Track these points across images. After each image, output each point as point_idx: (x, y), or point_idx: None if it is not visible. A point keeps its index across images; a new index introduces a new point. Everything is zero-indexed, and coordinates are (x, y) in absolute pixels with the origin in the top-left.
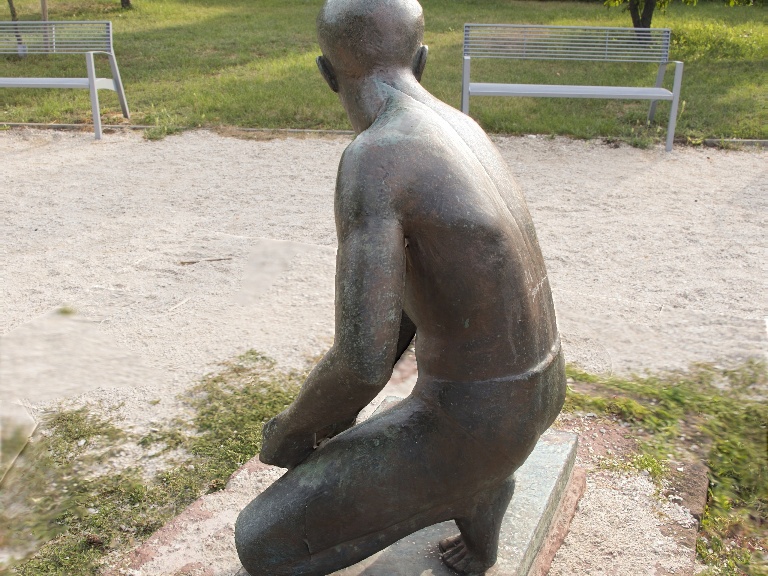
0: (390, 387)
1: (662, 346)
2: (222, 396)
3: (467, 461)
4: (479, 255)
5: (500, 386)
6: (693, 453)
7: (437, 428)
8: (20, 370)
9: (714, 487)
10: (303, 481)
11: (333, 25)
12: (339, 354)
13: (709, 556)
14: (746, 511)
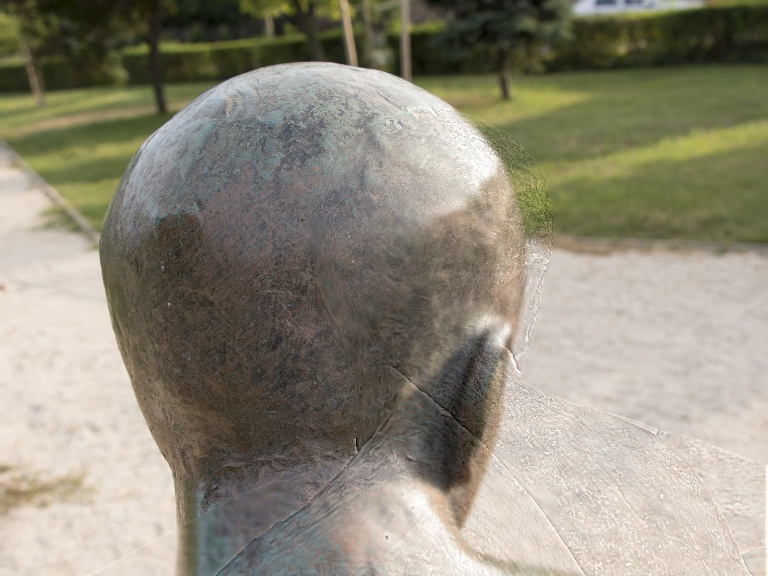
0: None
1: None
2: None
3: None
4: None
5: None
6: None
7: None
8: (195, 573)
9: None
10: None
11: (308, 220)
12: None
13: None
14: None
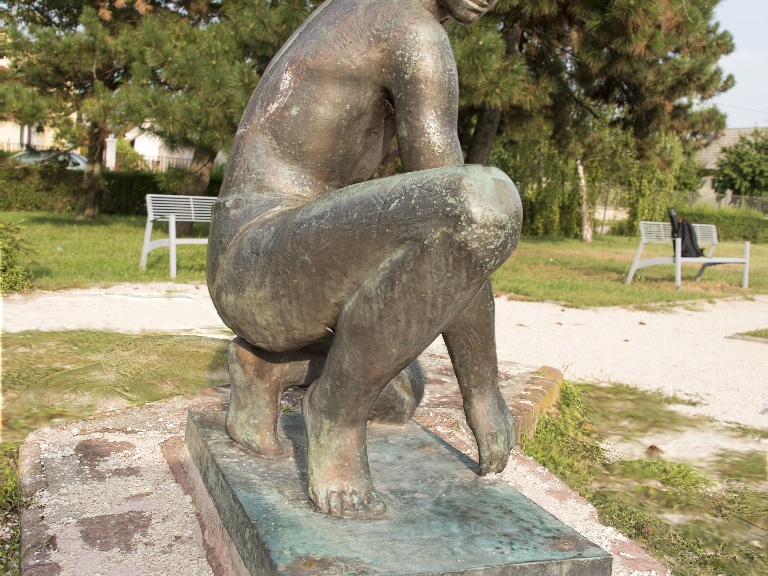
0: None
1: None
2: None
3: None
4: None
5: None
6: None
7: None
8: None
9: None
10: None
11: None
12: None
13: None
14: None
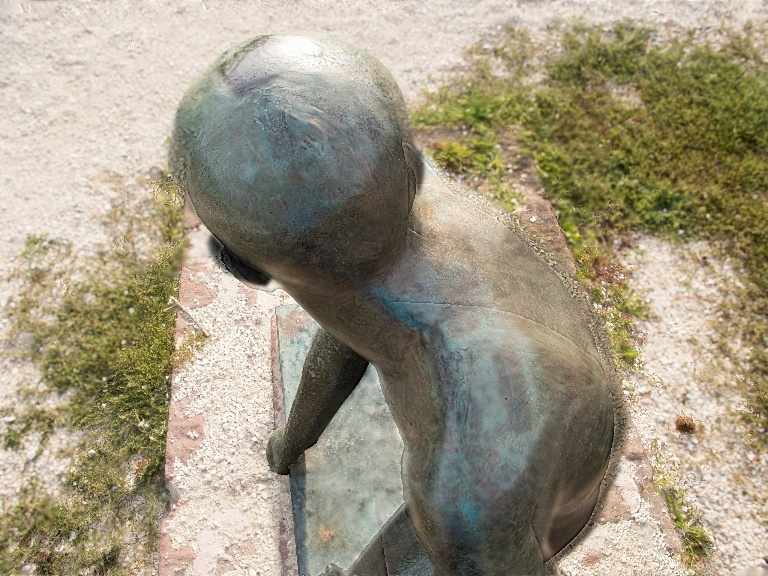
0: None
1: (426, 34)
2: (50, 330)
3: None
4: (595, 459)
5: (589, 499)
6: (527, 185)
7: None
8: None
9: (559, 219)
10: None
11: (274, 251)
12: None
13: (599, 313)
14: (592, 234)
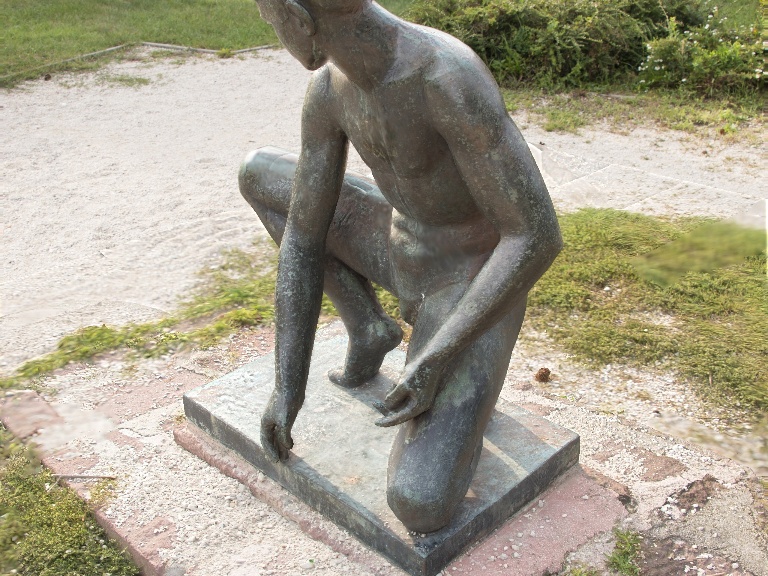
0: (66, 427)
1: (155, 277)
2: None
3: (525, 302)
4: None
5: None
6: None
7: None
8: None
9: None
10: (458, 401)
11: None
12: (541, 237)
13: None
14: None
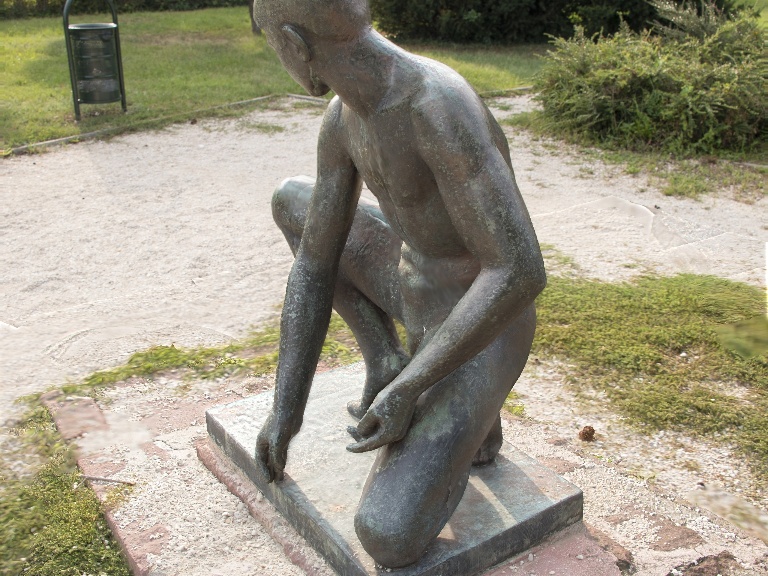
0: (109, 434)
1: (235, 306)
2: None
3: (527, 344)
4: None
5: None
6: None
7: (508, 327)
8: None
9: None
10: (433, 434)
11: None
12: (518, 271)
13: None
14: None
